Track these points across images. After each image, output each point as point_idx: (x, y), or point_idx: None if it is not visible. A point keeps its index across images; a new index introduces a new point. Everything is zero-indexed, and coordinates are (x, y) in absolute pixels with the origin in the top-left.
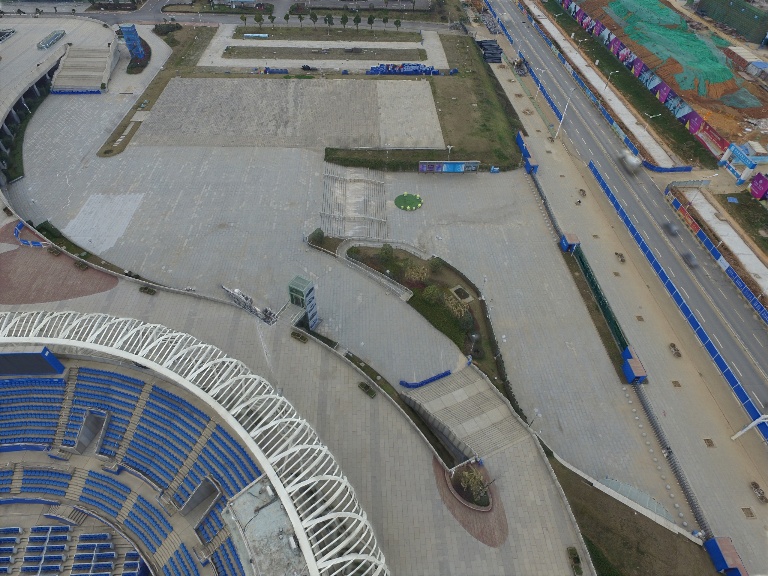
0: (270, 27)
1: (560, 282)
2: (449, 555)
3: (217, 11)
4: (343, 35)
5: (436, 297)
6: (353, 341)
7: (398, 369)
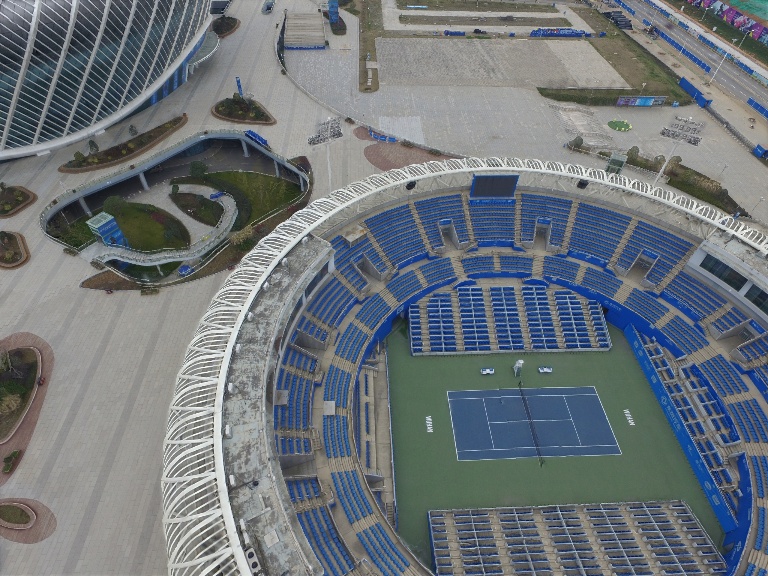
0: (425, 0)
1: (766, 176)
2: None
3: None
4: (490, 7)
5: (694, 177)
6: None
7: None
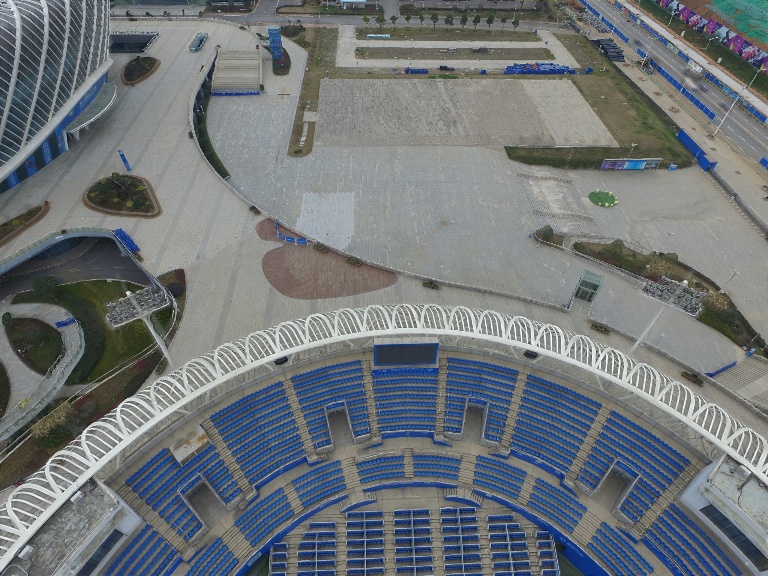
0: (389, 28)
1: None
2: None
3: (331, 12)
4: (462, 35)
5: None
6: None
7: (682, 360)
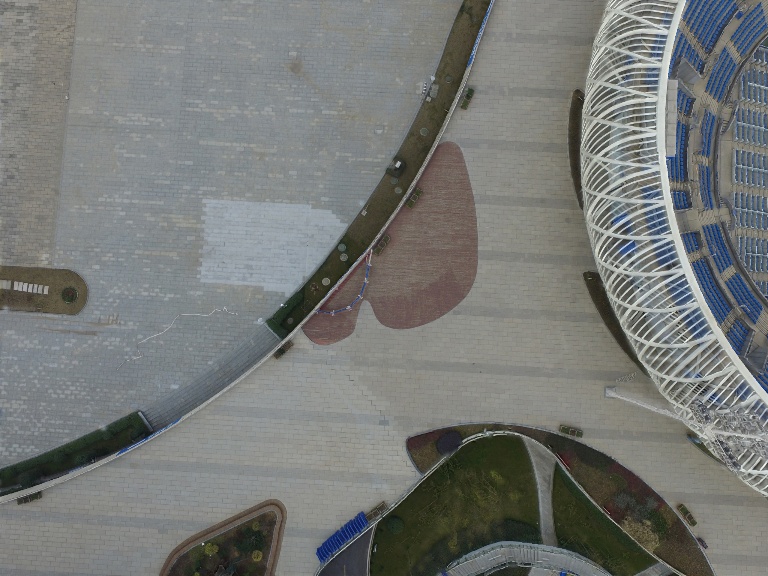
0: None
1: None
2: None
3: None
4: None
5: None
6: None
7: None
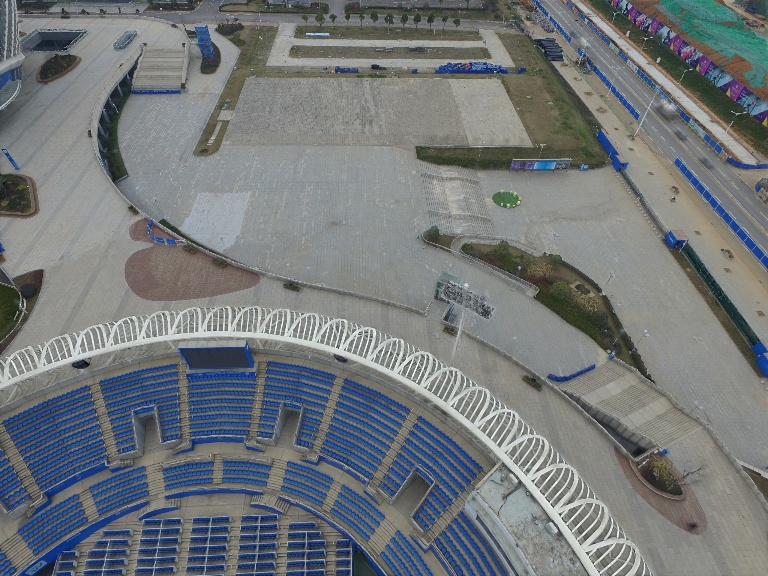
0: (330, 26)
1: (674, 278)
2: (656, 542)
3: (274, 11)
4: (403, 34)
5: (566, 293)
6: (491, 336)
7: (542, 363)
